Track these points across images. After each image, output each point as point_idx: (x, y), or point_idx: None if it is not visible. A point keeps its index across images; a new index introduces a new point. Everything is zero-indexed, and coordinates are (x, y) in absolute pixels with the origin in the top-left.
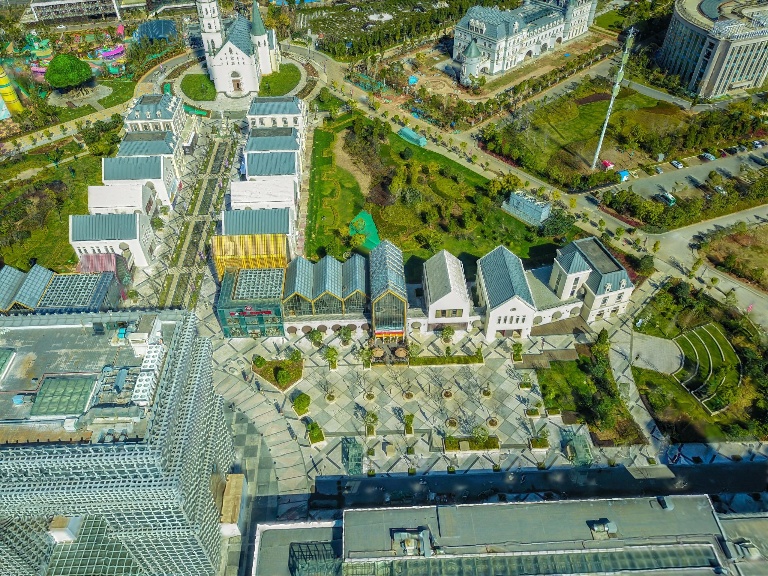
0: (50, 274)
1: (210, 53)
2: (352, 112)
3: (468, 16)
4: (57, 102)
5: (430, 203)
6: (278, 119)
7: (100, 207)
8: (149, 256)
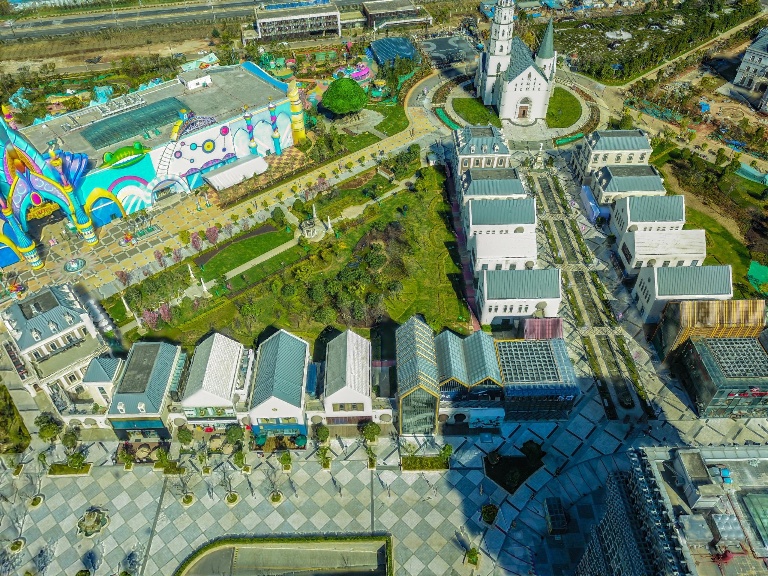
0: (492, 341)
1: (507, 78)
2: (666, 144)
3: (767, 38)
4: None
5: None
6: (624, 155)
7: (490, 257)
8: None
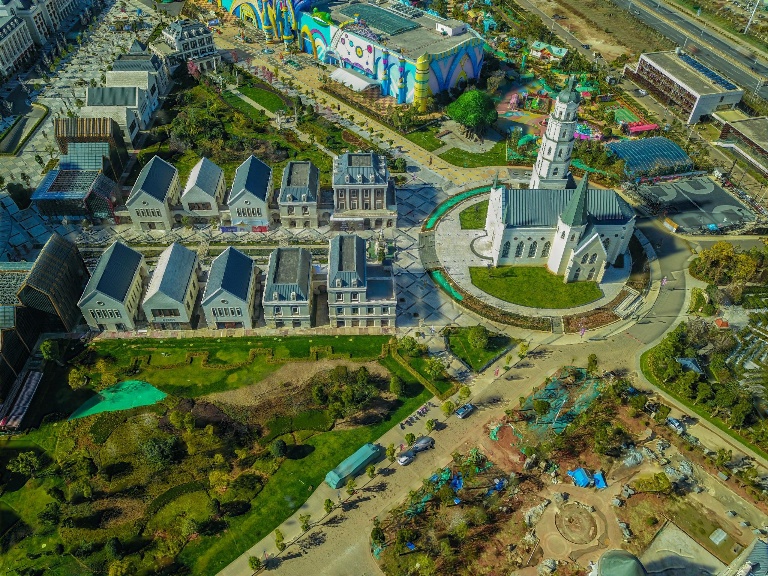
0: (99, 168)
1: (494, 184)
2: None
3: None
4: (450, 125)
5: (144, 477)
6: None
7: None
8: (143, 226)
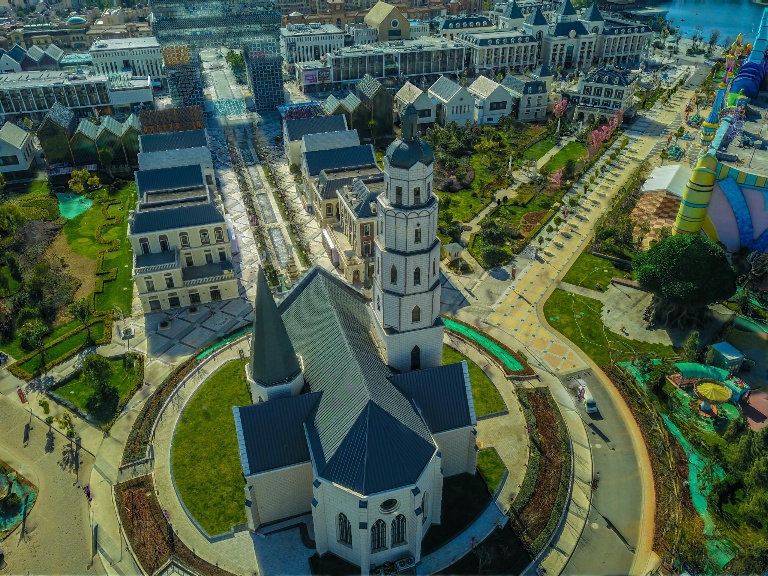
0: None
1: None
2: None
3: None
4: None
5: None
6: None
7: None
8: None
